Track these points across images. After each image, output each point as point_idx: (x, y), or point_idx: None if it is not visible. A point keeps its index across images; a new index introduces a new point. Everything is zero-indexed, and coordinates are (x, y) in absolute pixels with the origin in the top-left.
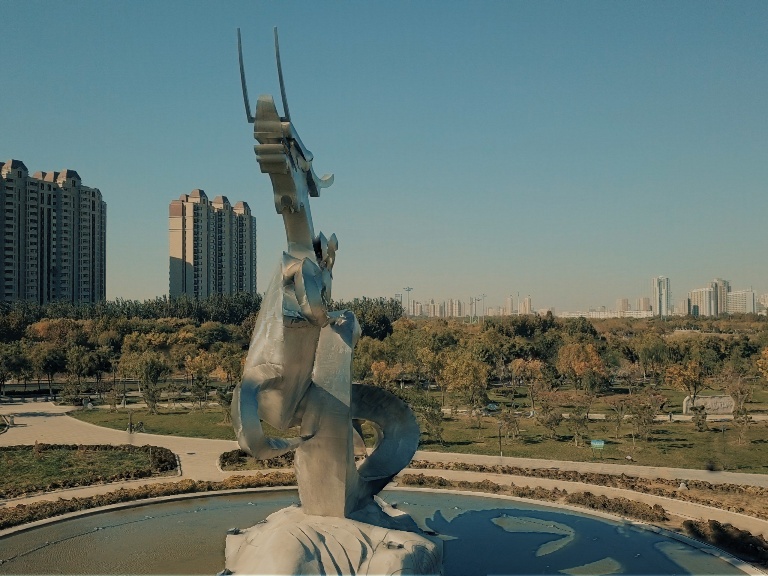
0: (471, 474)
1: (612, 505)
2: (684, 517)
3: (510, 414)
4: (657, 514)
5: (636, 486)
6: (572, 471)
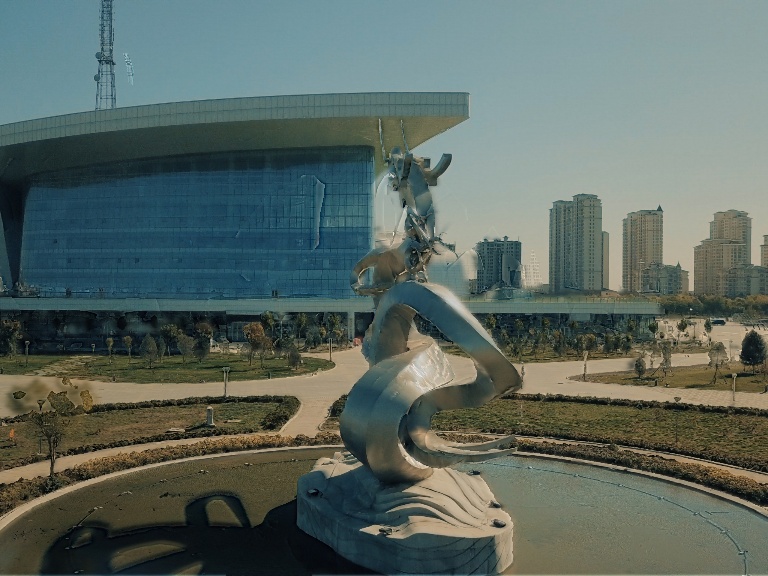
0: None
1: None
2: None
3: None
4: None
5: None
6: None
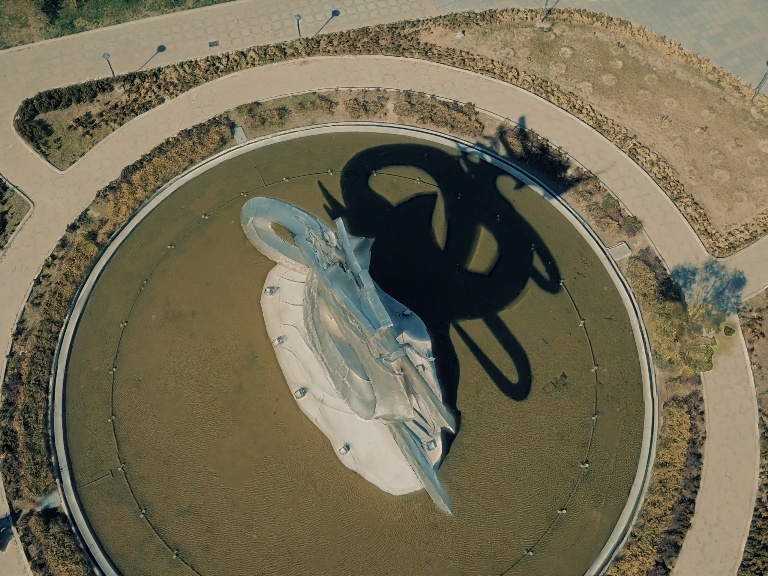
0: (281, 68)
1: (439, 119)
2: (491, 116)
3: None
4: (477, 128)
5: (430, 53)
6: (363, 31)
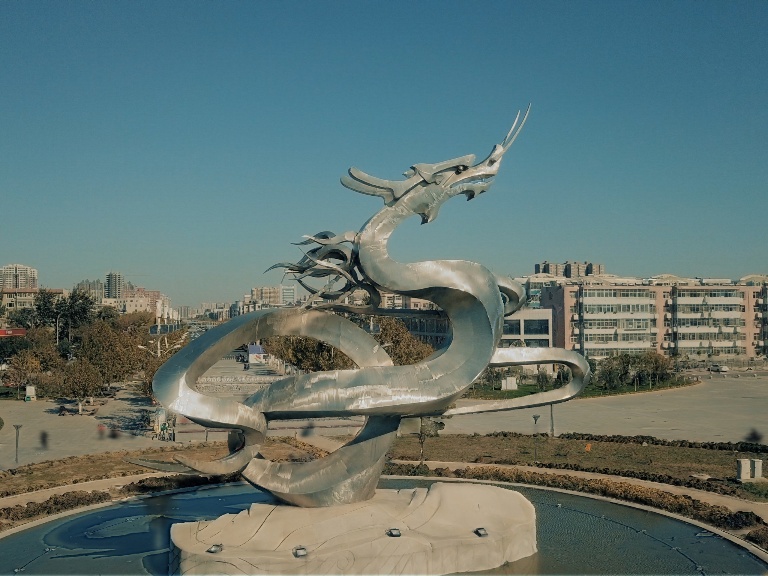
0: None
1: (66, 502)
2: None
3: None
4: None
5: None
6: None
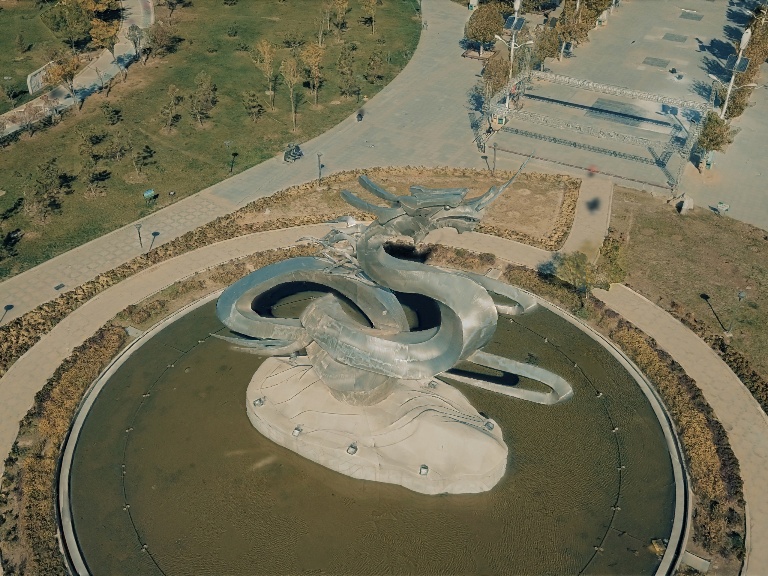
0: (136, 279)
1: None
2: None
3: (38, 194)
4: None
5: (255, 227)
6: (189, 234)
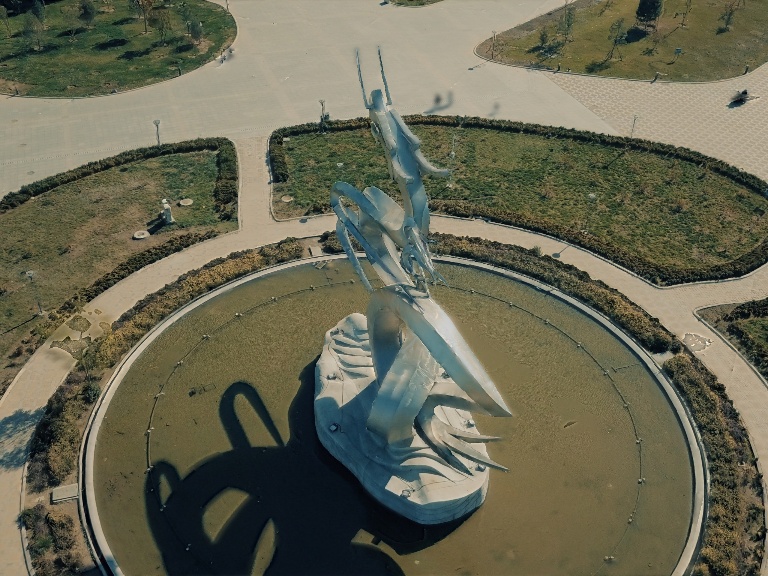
0: None
1: None
2: None
3: None
4: None
5: None
6: None
